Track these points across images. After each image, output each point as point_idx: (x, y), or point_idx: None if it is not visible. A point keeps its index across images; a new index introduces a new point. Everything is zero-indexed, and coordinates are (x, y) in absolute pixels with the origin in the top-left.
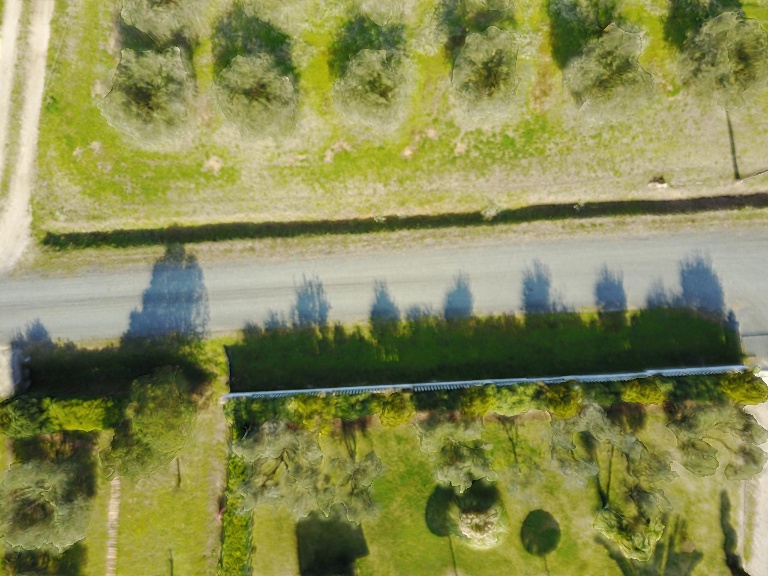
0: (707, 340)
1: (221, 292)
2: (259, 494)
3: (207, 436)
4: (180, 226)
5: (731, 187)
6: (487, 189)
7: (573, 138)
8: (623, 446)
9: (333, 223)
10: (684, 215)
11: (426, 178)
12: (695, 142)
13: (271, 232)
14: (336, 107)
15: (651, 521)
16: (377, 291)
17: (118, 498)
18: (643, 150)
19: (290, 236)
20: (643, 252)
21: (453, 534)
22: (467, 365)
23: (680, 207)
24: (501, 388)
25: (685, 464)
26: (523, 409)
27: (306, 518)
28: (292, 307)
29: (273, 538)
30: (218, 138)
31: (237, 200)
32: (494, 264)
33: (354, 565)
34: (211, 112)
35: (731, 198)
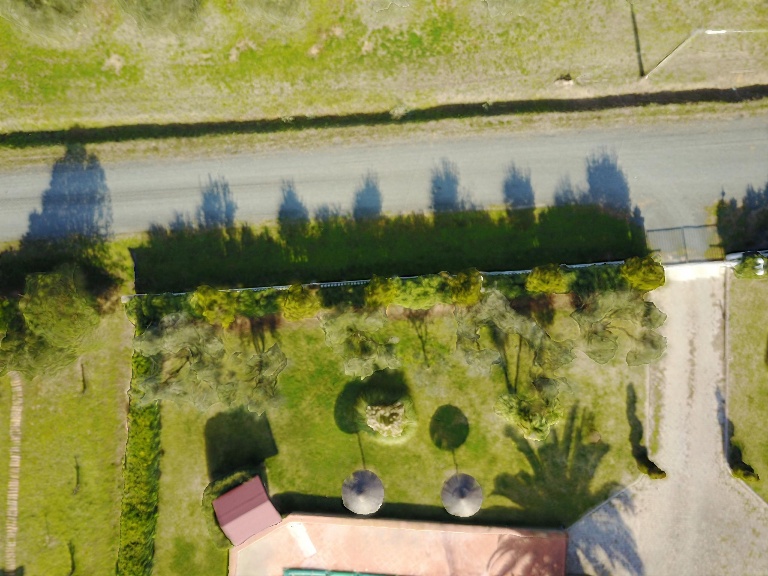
0: (613, 236)
1: (124, 193)
2: (159, 389)
3: (113, 342)
4: (82, 128)
5: (636, 84)
6: (395, 88)
7: (481, 36)
8: (524, 332)
9: (240, 124)
10: (590, 112)
11: (334, 77)
12: (601, 39)
13: (176, 133)
14: (239, 1)
15: (550, 402)
16: (284, 191)
17: (20, 405)
18: (550, 47)
19: (195, 136)
20: (550, 149)
21: (362, 431)
22: (376, 264)
23: (587, 105)
24: (406, 280)
25: (587, 351)
26: (428, 302)
27: (214, 420)
28: (198, 208)
29: (181, 441)
30: (119, 36)
31: (140, 100)
32: (402, 162)
33: (262, 465)
34: (111, 9)
35: (637, 96)
